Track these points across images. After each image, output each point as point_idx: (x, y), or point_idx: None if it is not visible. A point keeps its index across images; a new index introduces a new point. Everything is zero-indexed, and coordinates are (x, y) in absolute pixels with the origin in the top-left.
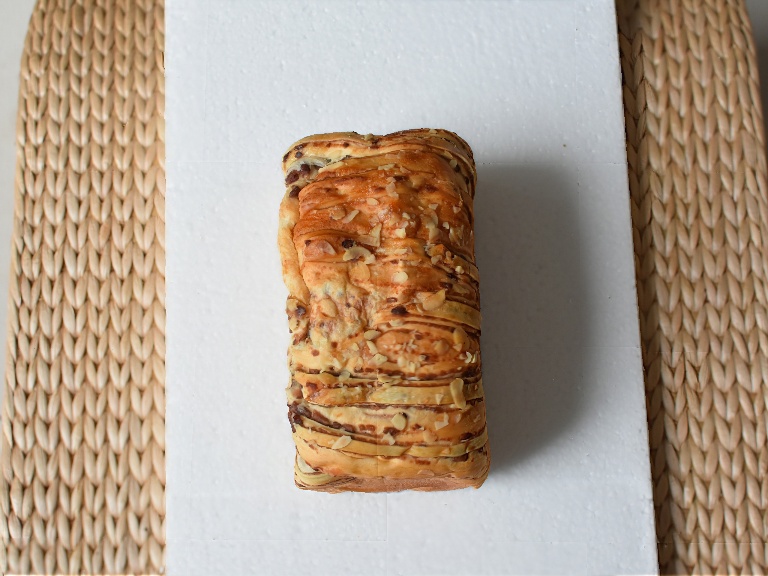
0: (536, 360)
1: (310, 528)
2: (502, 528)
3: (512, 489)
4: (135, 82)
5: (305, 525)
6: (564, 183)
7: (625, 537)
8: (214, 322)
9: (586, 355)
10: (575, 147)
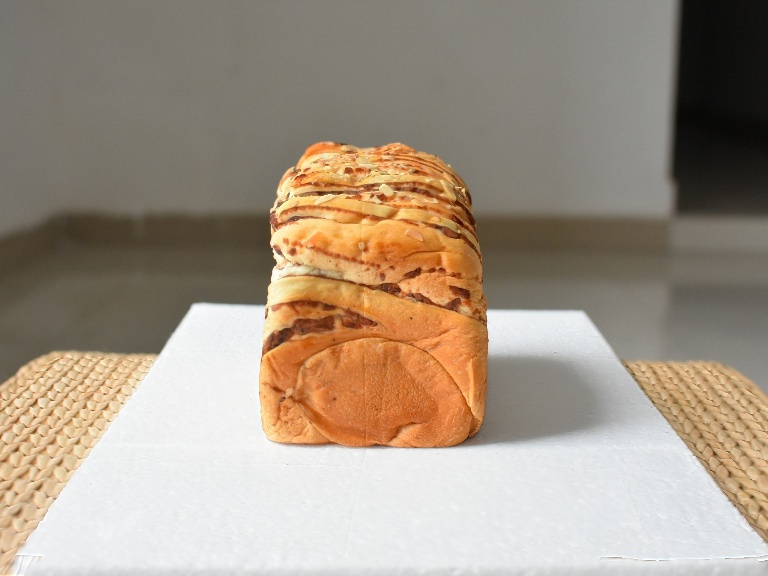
0: (539, 408)
1: (267, 460)
2: (509, 462)
3: (519, 450)
4: (146, 357)
5: (261, 459)
6: (557, 362)
7: (666, 468)
8: (187, 391)
9: (595, 407)
10: (566, 354)
